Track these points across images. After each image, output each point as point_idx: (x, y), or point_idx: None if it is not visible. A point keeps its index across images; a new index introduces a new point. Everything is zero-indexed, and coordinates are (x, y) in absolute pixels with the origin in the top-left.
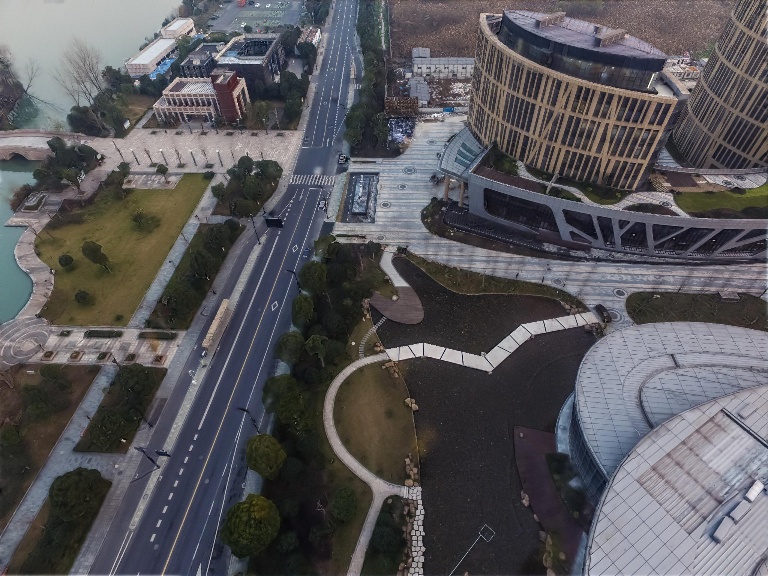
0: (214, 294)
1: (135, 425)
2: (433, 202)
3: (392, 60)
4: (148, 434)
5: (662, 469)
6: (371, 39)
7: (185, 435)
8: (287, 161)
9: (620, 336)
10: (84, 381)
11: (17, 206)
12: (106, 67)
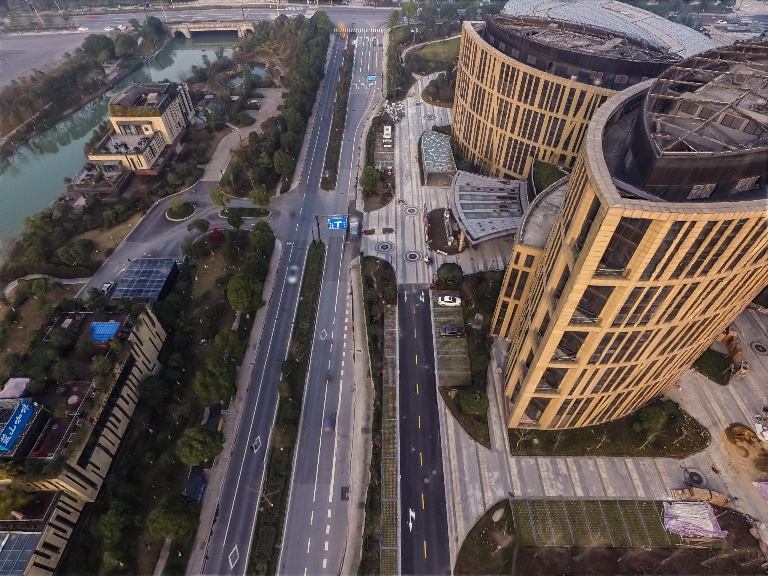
0: None
1: None
2: (760, 36)
3: None
4: None
5: (620, 5)
6: None
7: None
8: (753, 13)
9: (683, 26)
10: None
11: None
12: None
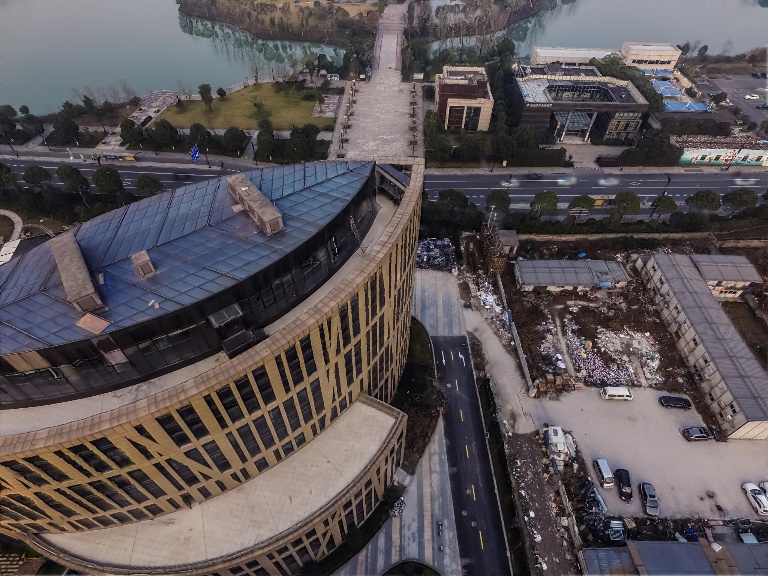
0: (156, 154)
1: (31, 133)
2: None
3: (709, 245)
4: (46, 150)
5: None
6: (748, 201)
7: (33, 162)
8: None
9: None
10: (108, 124)
11: (305, 68)
12: (506, 38)
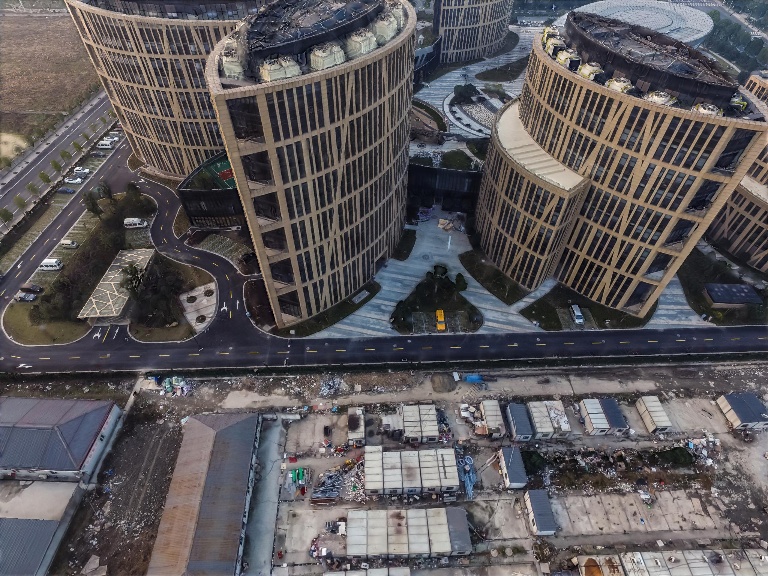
0: None
1: None
2: None
3: None
4: None
5: None
6: None
7: None
8: None
9: None
10: None
11: None
12: None
